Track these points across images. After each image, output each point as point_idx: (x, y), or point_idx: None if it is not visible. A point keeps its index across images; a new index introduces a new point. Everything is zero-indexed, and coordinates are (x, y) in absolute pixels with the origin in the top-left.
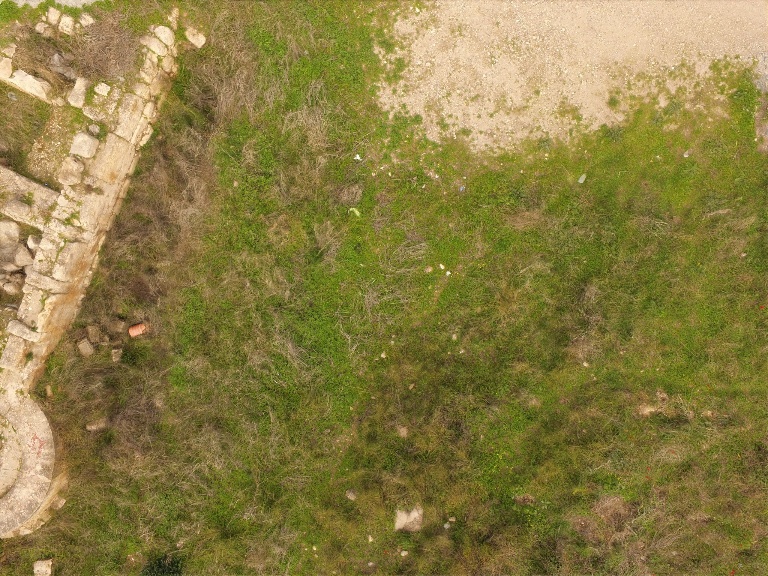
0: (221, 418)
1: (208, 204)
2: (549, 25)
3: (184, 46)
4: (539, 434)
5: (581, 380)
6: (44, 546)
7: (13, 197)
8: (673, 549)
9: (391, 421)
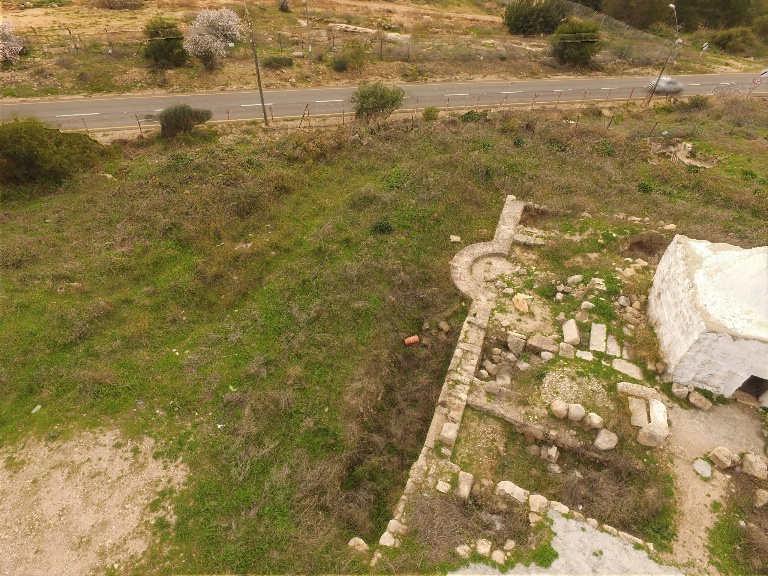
0: None
1: None
2: None
3: None
4: (150, 275)
5: None
6: None
7: (502, 399)
8: None
9: None
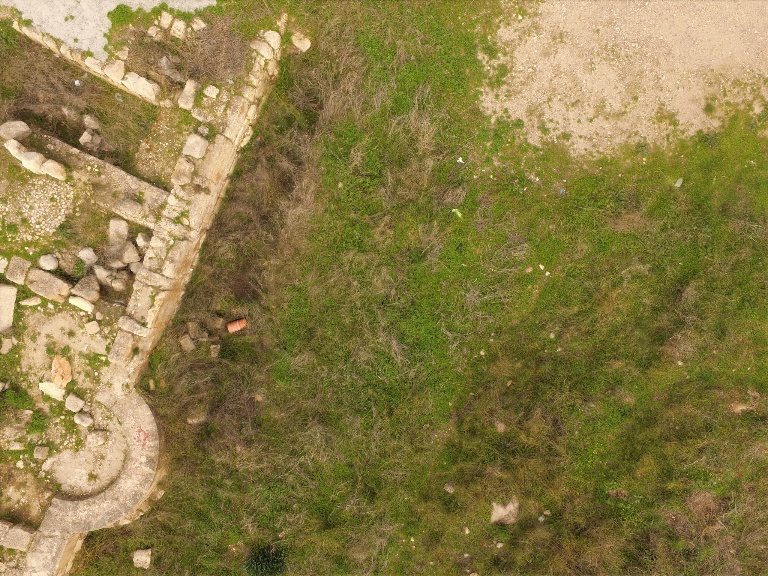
0: (323, 412)
1: (316, 204)
2: (648, 33)
3: (287, 50)
4: (633, 430)
5: (674, 378)
6: (143, 536)
7: (124, 196)
8: (761, 543)
9: (491, 417)
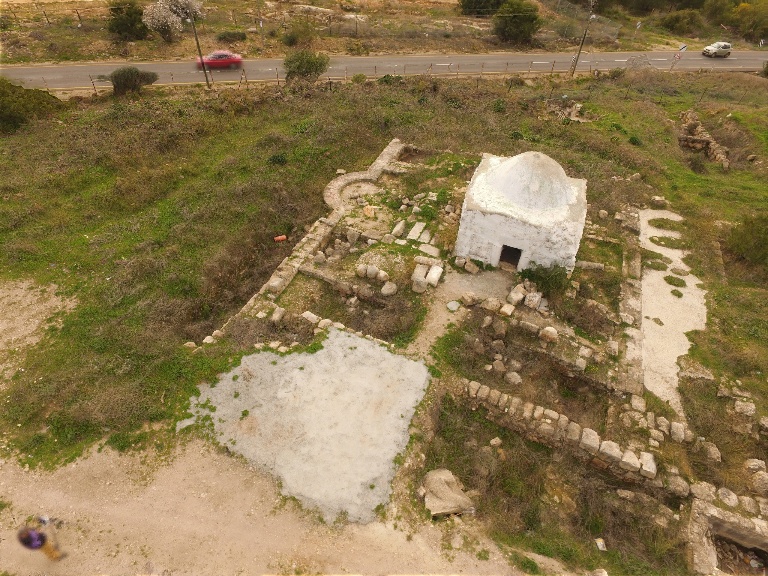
0: None
1: None
2: None
3: None
4: (79, 190)
5: None
6: None
7: (325, 267)
8: None
9: None
